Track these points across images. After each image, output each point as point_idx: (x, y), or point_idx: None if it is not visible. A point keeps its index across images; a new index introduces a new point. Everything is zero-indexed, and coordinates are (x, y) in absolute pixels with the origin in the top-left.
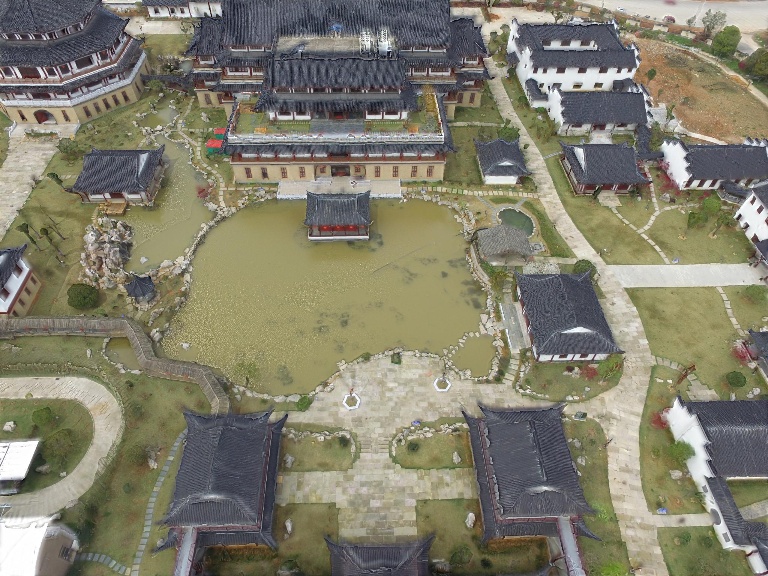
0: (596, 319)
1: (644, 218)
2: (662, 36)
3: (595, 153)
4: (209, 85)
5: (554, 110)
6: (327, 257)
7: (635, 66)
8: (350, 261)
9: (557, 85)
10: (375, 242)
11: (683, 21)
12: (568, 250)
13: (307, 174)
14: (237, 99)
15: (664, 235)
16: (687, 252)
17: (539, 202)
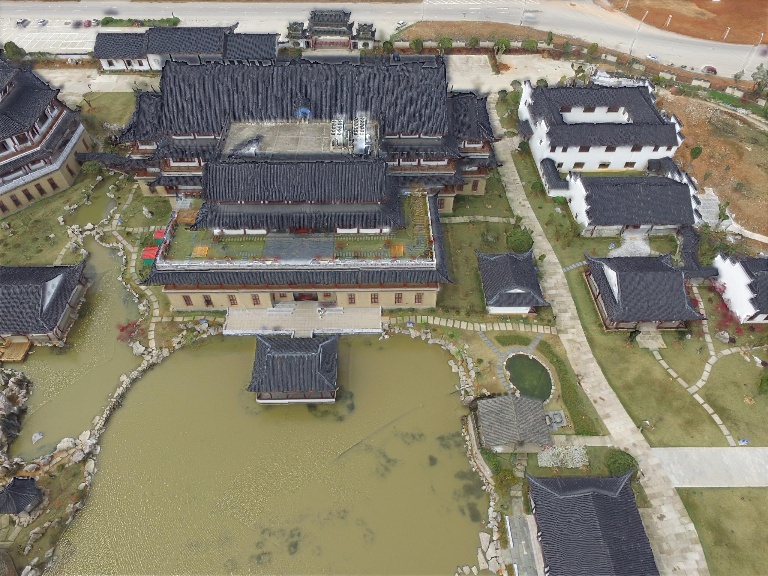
0: (643, 568)
1: (696, 368)
2: (703, 93)
3: (631, 278)
4: (152, 172)
5: (576, 203)
6: (279, 430)
7: (676, 144)
8: (309, 434)
9: (581, 175)
10: (344, 405)
11: (726, 72)
12: (598, 422)
13: (262, 301)
14: (173, 207)
15: (725, 397)
16: (757, 426)
17: (558, 341)
